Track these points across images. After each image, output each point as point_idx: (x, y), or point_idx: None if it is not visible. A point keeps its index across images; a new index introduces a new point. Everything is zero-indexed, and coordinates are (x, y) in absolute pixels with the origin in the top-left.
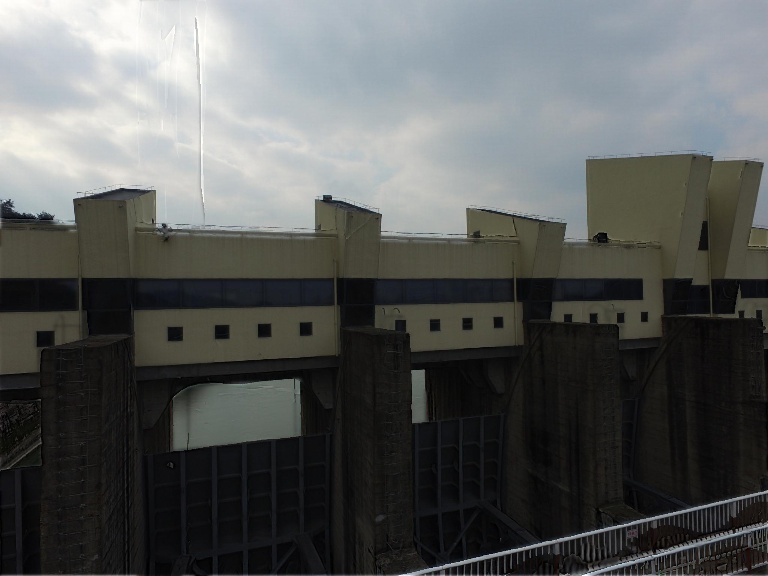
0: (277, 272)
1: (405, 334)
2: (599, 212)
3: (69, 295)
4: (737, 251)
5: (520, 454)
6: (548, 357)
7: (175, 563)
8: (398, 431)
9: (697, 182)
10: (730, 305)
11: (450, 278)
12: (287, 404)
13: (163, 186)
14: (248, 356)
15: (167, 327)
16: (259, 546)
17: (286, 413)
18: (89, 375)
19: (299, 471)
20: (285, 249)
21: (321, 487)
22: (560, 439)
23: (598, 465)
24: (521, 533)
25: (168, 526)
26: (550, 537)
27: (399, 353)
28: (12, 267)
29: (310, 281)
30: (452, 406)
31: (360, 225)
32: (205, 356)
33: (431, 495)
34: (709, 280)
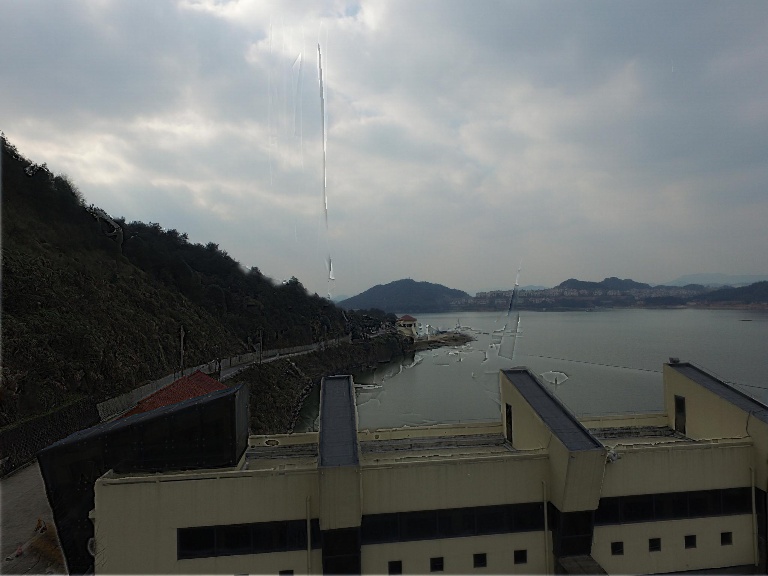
0: (699, 484)
1: None
2: None
3: (533, 515)
4: None
5: None
6: None
7: None
8: None
9: None
10: None
11: None
12: None
13: None
14: (676, 567)
15: (610, 542)
16: None
17: None
18: None
19: None
20: (705, 461)
21: None
22: None
23: None
24: None
25: None
26: None
27: None
28: (494, 495)
29: (728, 491)
30: None
31: None
32: (641, 568)
33: None
34: None
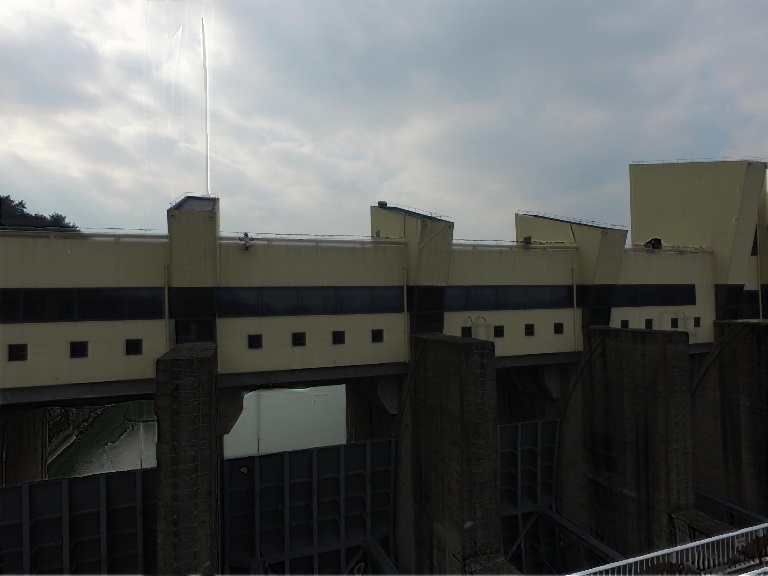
0: (350, 280)
1: (490, 342)
2: (644, 217)
3: (155, 304)
4: None
5: (578, 459)
6: (612, 363)
7: (250, 567)
8: (484, 438)
9: (751, 188)
10: None
11: (513, 285)
12: (306, 405)
13: None
14: (323, 363)
15: (247, 335)
16: (328, 550)
17: (307, 414)
18: (201, 385)
19: (366, 476)
20: (357, 257)
21: (385, 491)
22: (626, 445)
23: (670, 471)
24: (586, 538)
25: (241, 530)
26: (614, 542)
27: (486, 361)
28: (102, 276)
29: (381, 288)
30: (498, 410)
31: (433, 233)
32: (283, 363)
33: None
34: (758, 285)
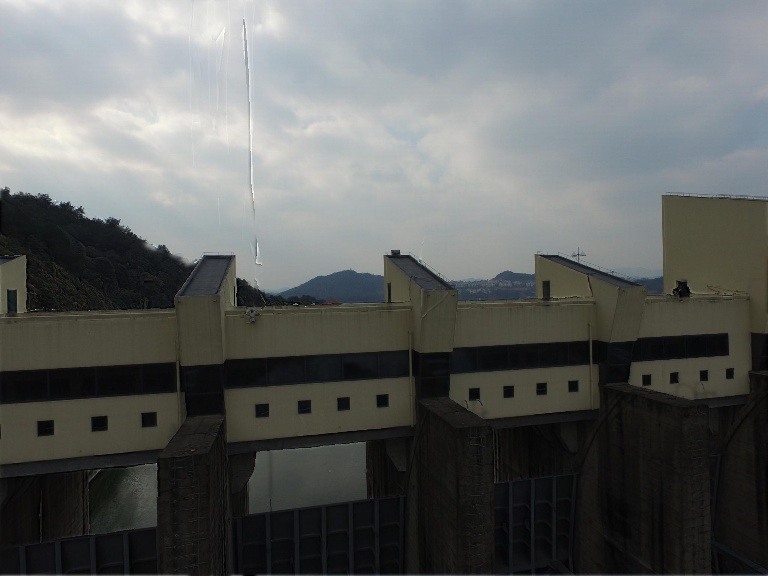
0: (355, 346)
1: (487, 426)
2: (676, 252)
3: (168, 377)
4: None
5: (595, 518)
6: (628, 427)
7: None
8: (481, 523)
9: None
10: None
11: (524, 343)
12: None
13: (216, 185)
14: (328, 429)
15: (255, 404)
16: None
17: None
18: (199, 480)
19: (375, 532)
20: (362, 324)
21: (395, 545)
22: (641, 514)
23: (685, 551)
24: None
25: None
26: None
27: (482, 446)
28: (119, 355)
29: (386, 354)
30: (518, 451)
31: (436, 303)
32: (289, 430)
33: (502, 554)
34: None
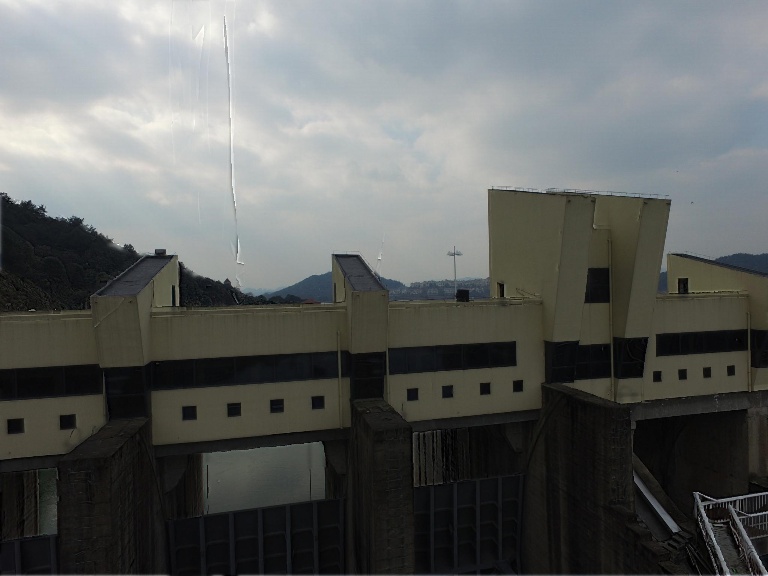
0: (31, 360)
1: (104, 457)
2: (497, 252)
3: None
4: (640, 305)
5: (352, 548)
6: (359, 450)
7: None
8: (92, 572)
9: (576, 229)
10: (637, 367)
11: (254, 355)
12: None
13: (196, 184)
14: None
15: None
16: None
17: None
18: None
19: None
20: (41, 334)
21: None
22: (364, 550)
23: None
24: None
25: None
26: None
27: None
28: None
29: (73, 368)
30: (331, 467)
31: (110, 310)
32: None
33: None
34: (610, 338)
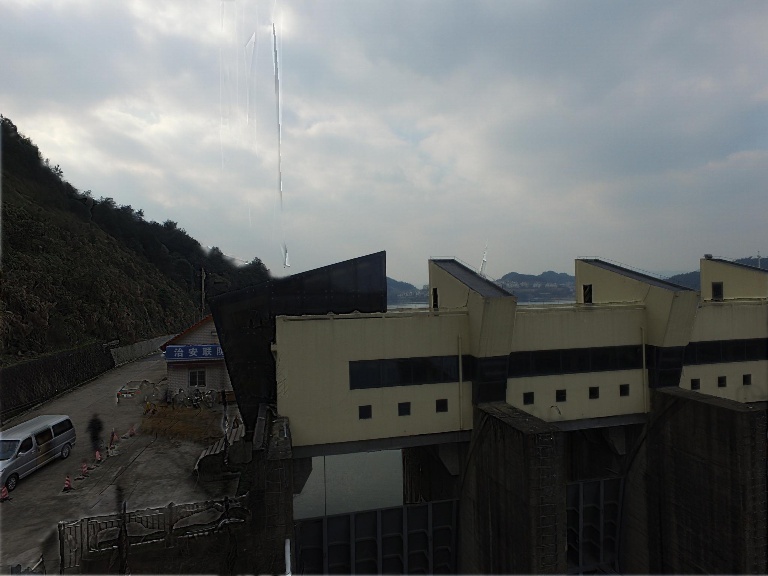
0: (753, 333)
1: None
2: None
3: (632, 357)
4: None
5: None
6: None
7: None
8: None
9: None
10: None
11: None
12: None
13: None
14: (737, 400)
15: (690, 379)
16: None
17: None
18: (766, 429)
19: None
20: (758, 315)
21: None
22: None
23: None
24: None
25: None
26: None
27: None
28: (604, 338)
29: None
30: None
31: None
32: None
33: None
34: None
